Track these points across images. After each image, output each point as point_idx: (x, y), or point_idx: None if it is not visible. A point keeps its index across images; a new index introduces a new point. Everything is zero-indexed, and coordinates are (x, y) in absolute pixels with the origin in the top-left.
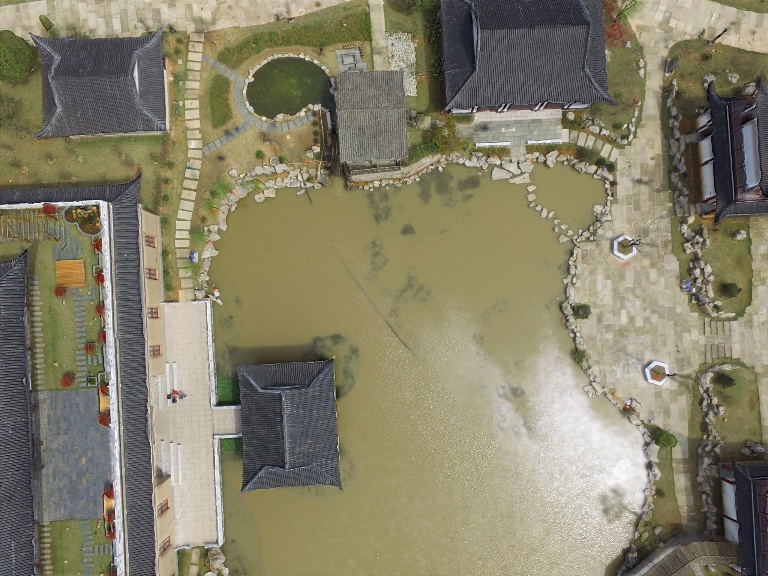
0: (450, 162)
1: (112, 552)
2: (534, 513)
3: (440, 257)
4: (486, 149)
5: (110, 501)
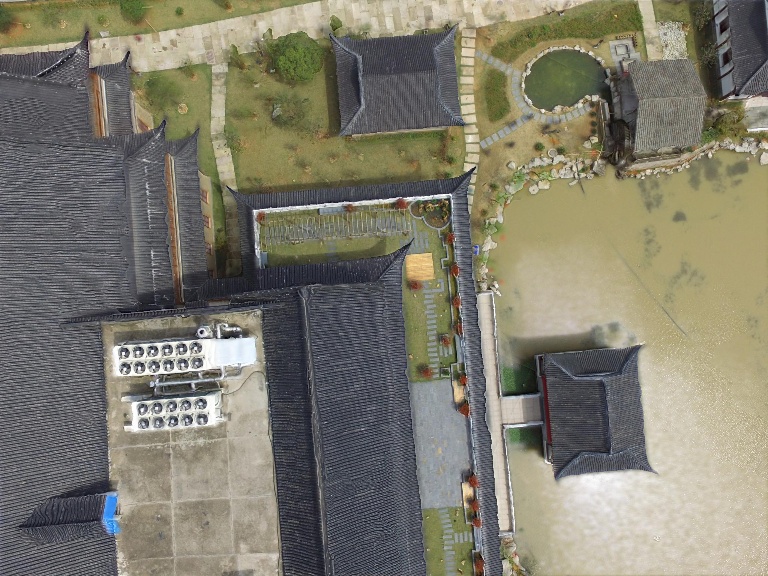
0: (722, 148)
1: (472, 539)
2: None
3: (709, 243)
4: (757, 134)
5: (469, 489)
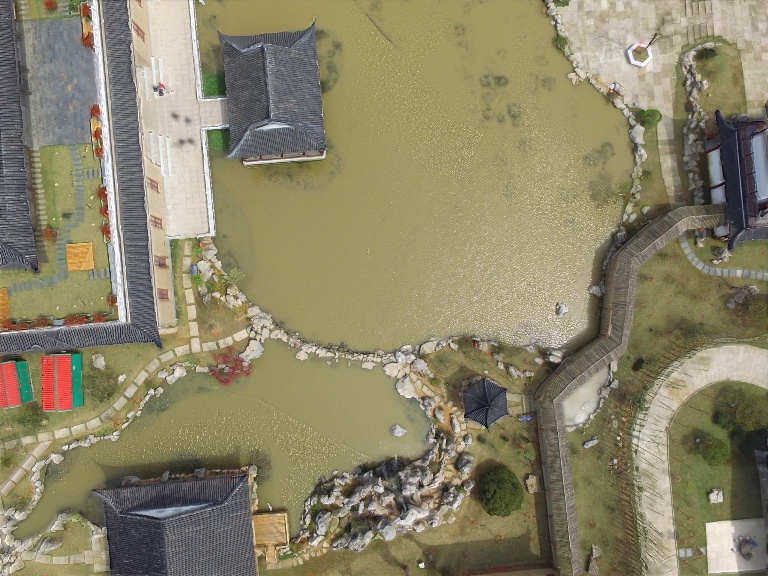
0: None
1: (101, 174)
2: (522, 203)
3: None
4: None
5: (97, 124)
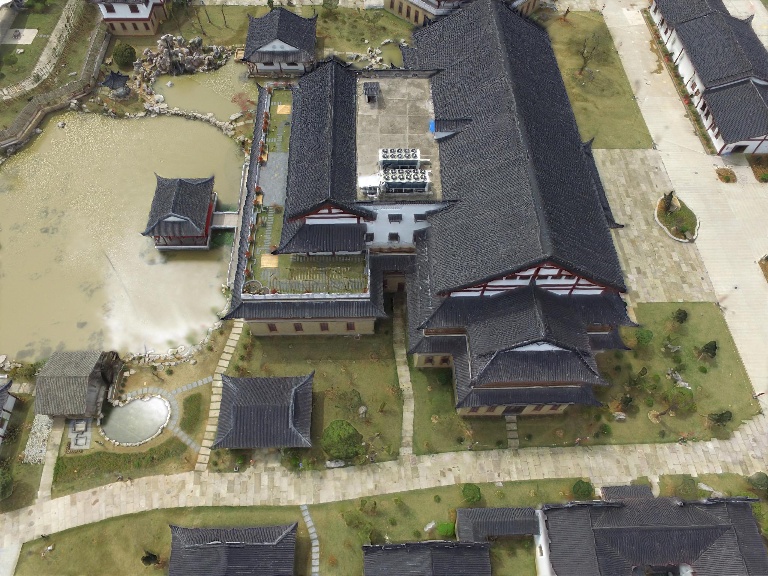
0: None
1: (267, 139)
2: None
3: None
4: (1, 374)
5: (264, 158)
